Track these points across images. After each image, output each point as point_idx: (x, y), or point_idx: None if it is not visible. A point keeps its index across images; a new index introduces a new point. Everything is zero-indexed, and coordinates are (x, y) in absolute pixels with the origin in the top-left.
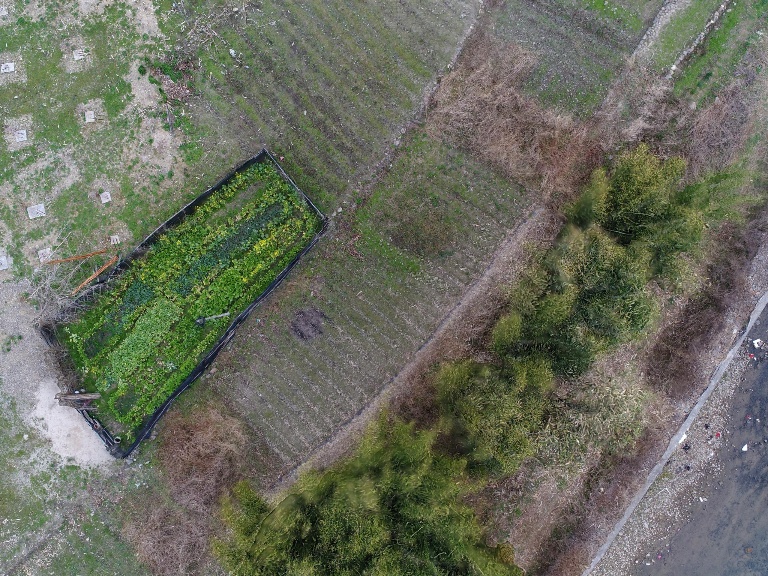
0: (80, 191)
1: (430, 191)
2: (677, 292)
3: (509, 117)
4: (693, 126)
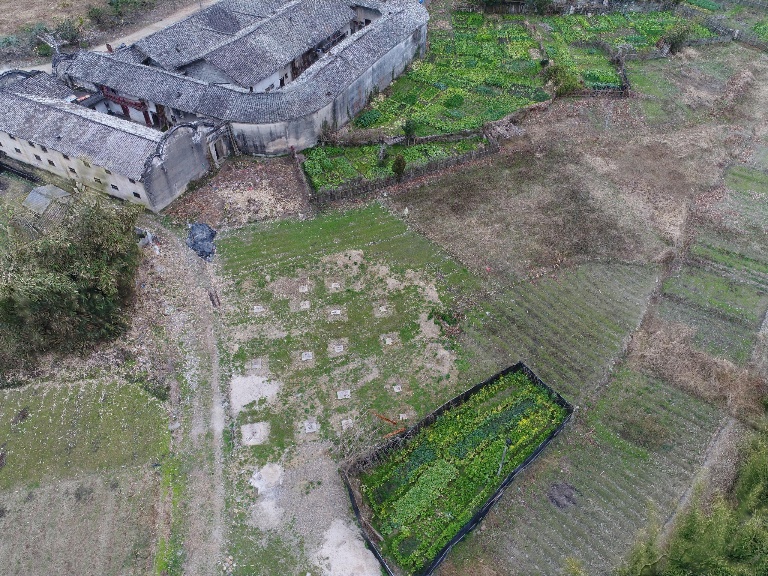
0: (378, 384)
1: (642, 403)
2: None
3: (687, 360)
4: None
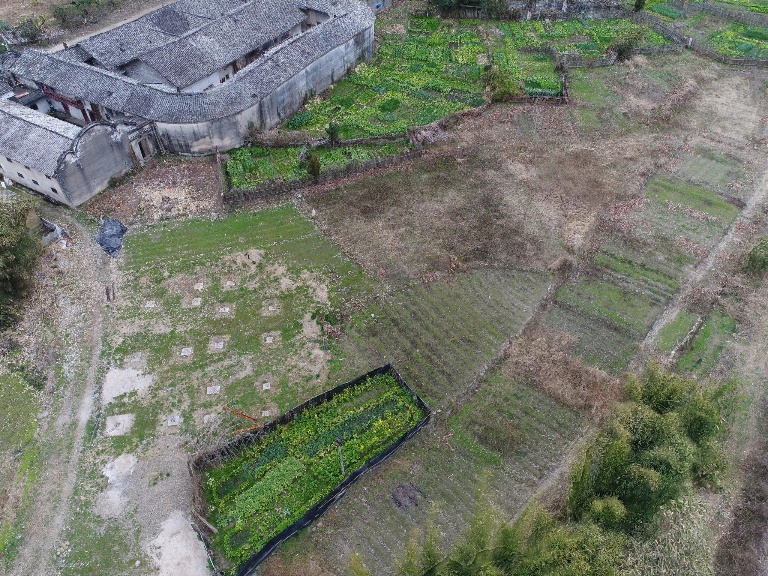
0: (249, 381)
1: (507, 409)
2: (719, 492)
3: (561, 368)
4: (698, 389)
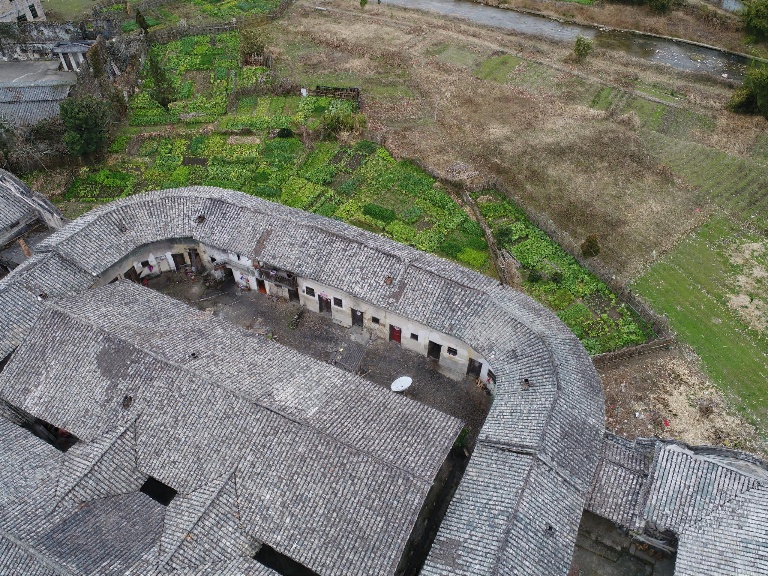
0: None
1: None
2: None
3: (728, 136)
4: None
